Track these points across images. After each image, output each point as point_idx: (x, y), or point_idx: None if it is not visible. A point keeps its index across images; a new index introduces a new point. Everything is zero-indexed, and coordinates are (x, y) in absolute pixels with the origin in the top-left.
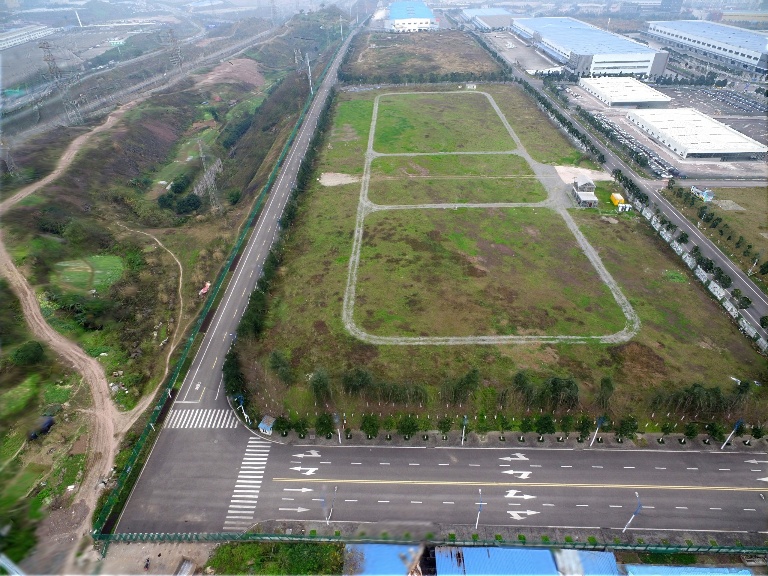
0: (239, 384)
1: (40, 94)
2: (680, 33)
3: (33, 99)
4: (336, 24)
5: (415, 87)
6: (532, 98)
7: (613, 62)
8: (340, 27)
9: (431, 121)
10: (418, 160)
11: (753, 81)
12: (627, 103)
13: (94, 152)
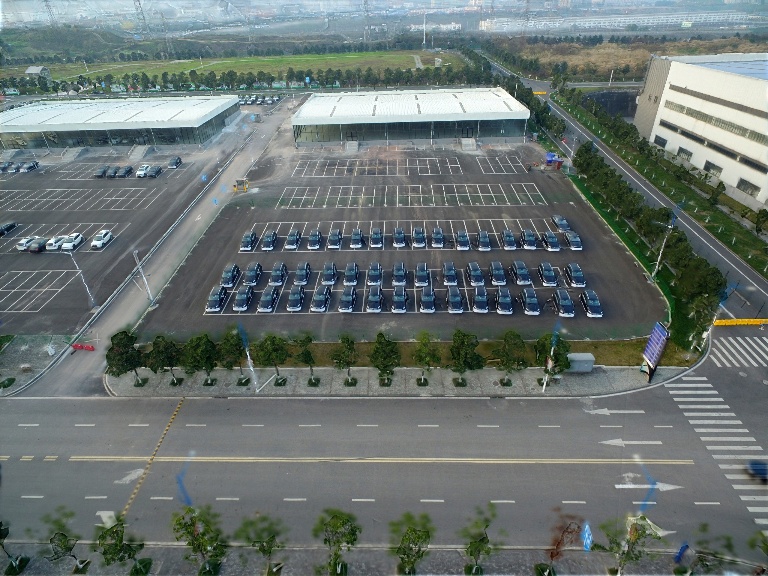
0: (7, 62)
1: (335, 13)
2: None
3: (326, 14)
4: None
5: None
6: (389, 85)
7: (702, 95)
8: None
9: (292, 64)
10: (189, 66)
11: None
12: None
13: (289, 43)
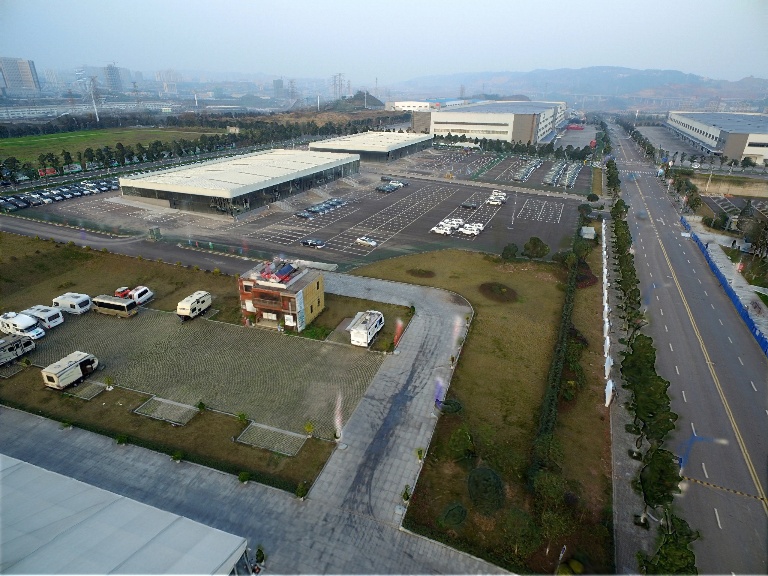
0: None
1: None
2: (681, 118)
3: None
4: (312, 98)
5: (188, 128)
6: (264, 143)
7: (458, 123)
8: (317, 101)
9: None
10: None
11: (664, 162)
12: (330, 150)
13: None
